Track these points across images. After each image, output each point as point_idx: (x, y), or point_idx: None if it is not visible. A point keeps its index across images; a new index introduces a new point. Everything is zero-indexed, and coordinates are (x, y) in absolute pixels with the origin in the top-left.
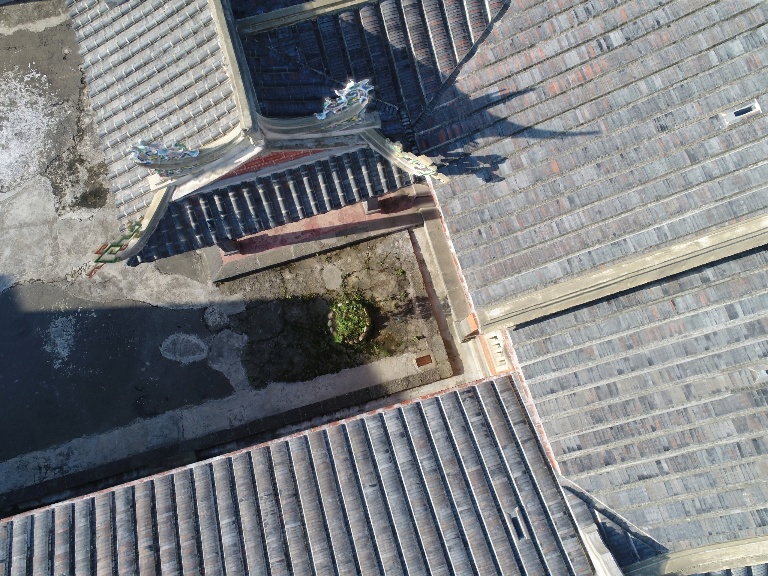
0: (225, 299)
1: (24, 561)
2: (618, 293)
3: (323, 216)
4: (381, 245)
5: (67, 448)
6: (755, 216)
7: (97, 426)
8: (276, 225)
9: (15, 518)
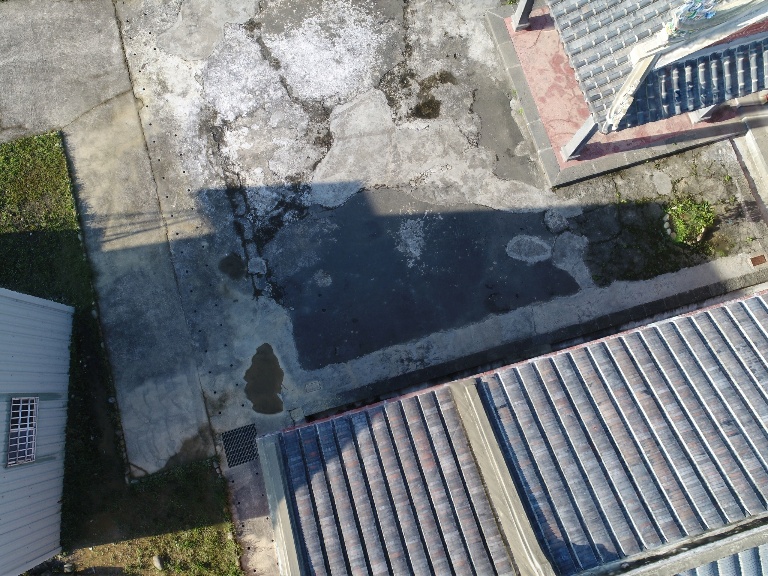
0: (562, 203)
1: (526, 405)
2: None
3: (651, 125)
4: (706, 153)
5: (426, 342)
6: None
7: (453, 321)
8: None
9: (497, 371)
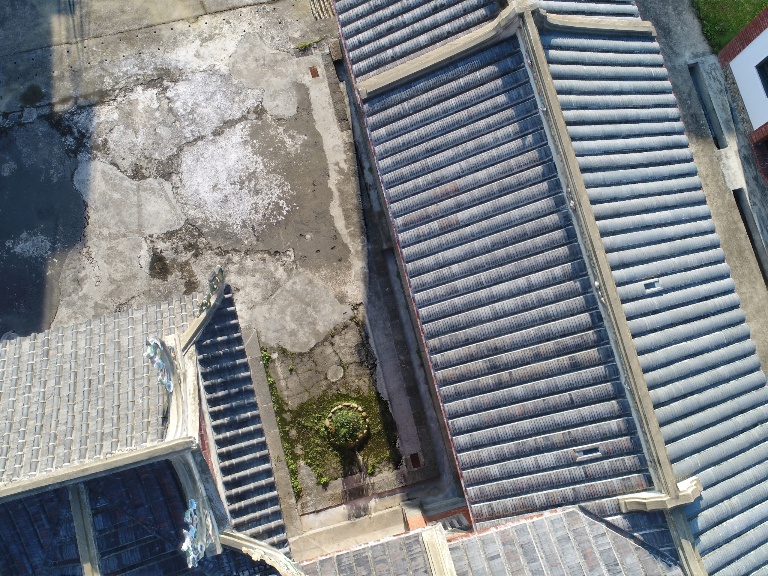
0: None
1: None
2: None
3: None
4: None
5: None
6: None
7: None
8: None
9: None
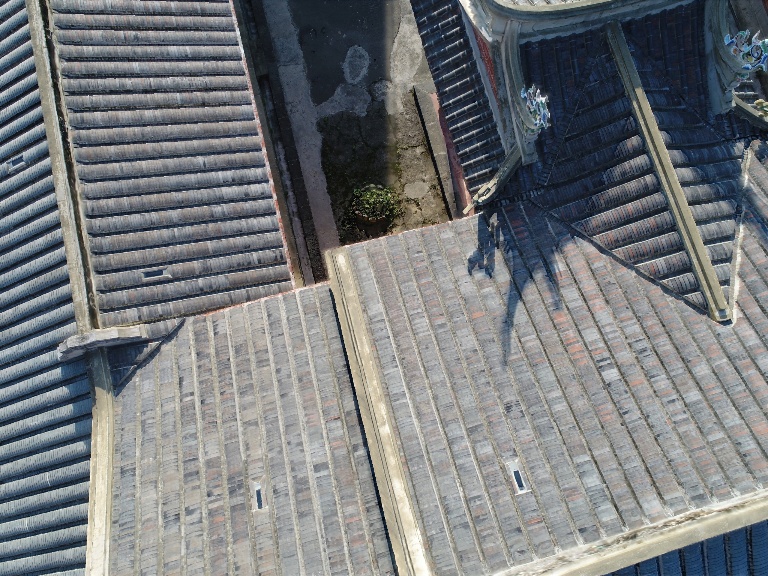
0: (399, 97)
1: None
2: None
3: None
4: None
5: None
6: None
7: None
8: (436, 84)
9: None
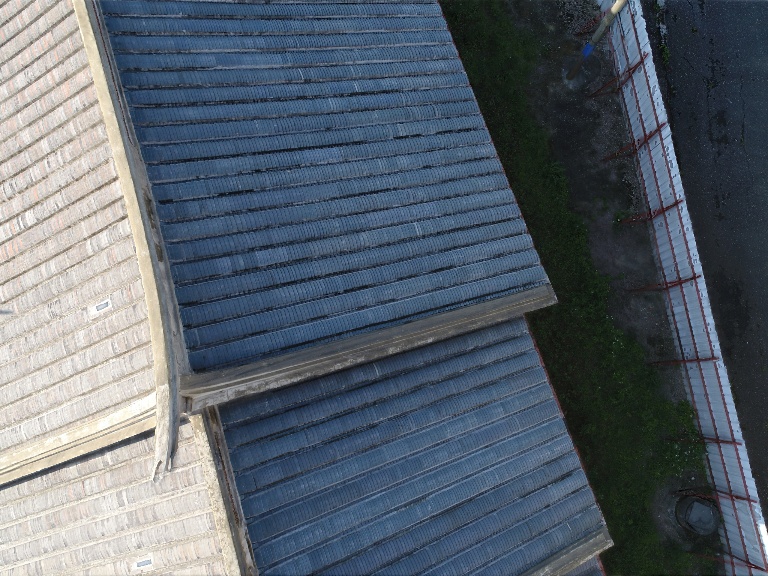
0: None
1: None
2: (49, 469)
3: None
4: None
5: None
6: (99, 416)
7: None
8: None
9: None
